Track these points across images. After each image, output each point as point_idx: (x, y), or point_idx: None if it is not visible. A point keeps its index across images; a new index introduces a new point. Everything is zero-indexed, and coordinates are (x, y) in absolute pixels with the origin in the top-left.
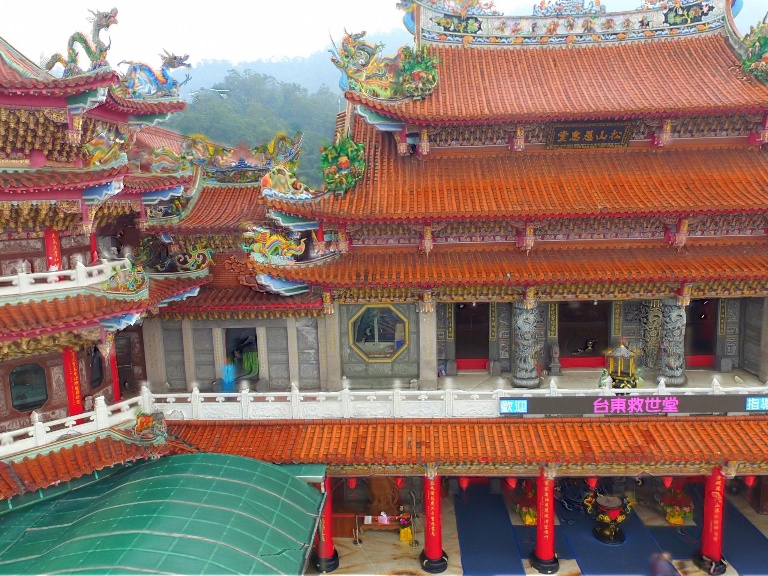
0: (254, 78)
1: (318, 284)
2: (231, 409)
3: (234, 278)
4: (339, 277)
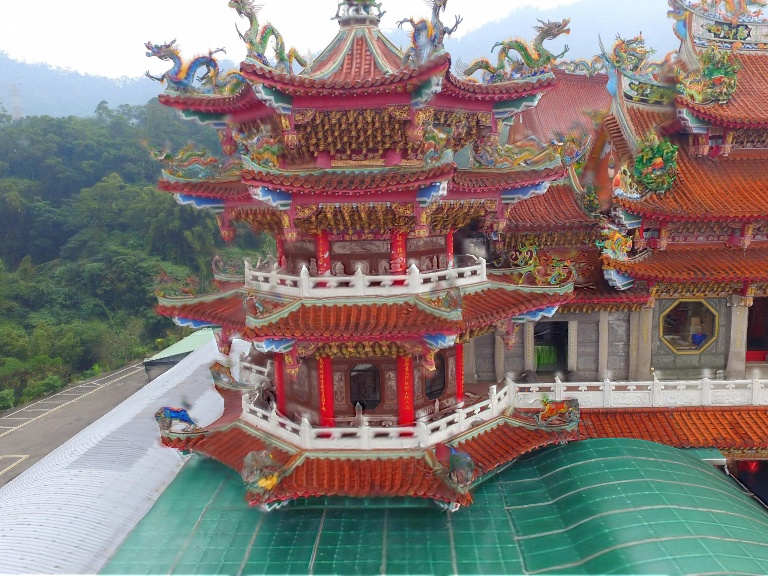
0: None
1: (652, 279)
2: (592, 398)
3: None
4: (677, 272)
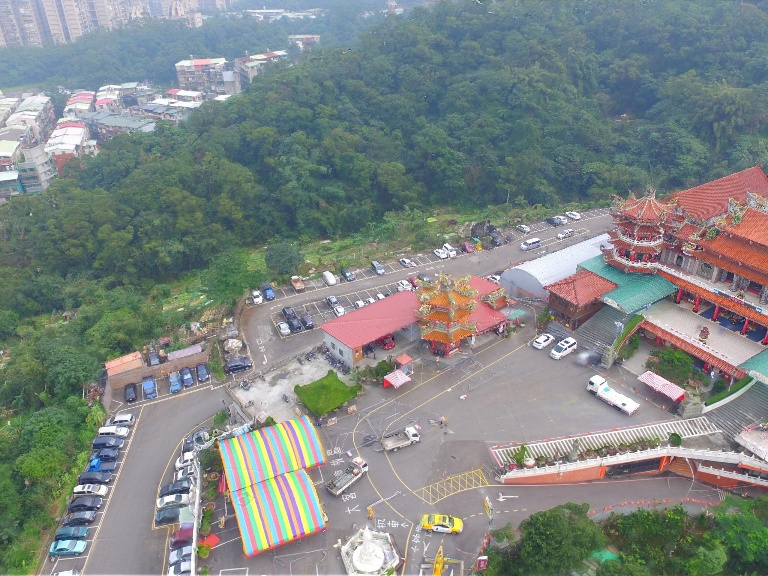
0: None
1: None
2: (670, 271)
3: None
4: None
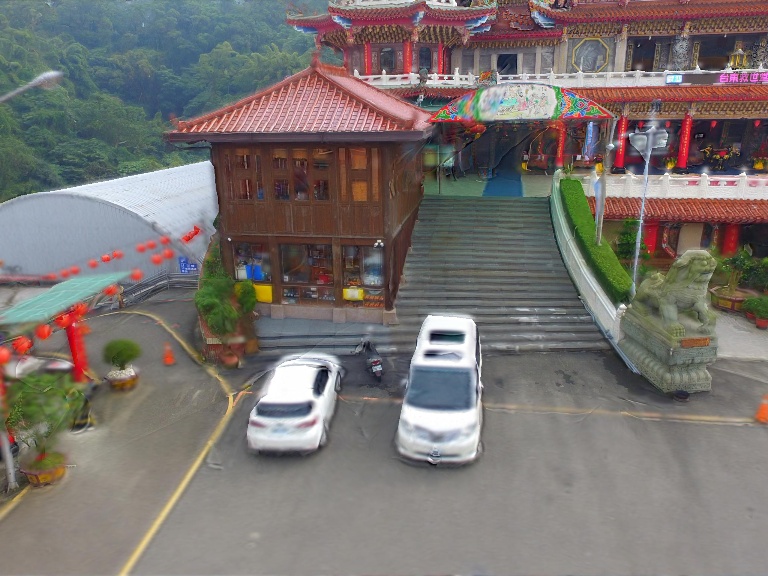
0: None
1: (563, 20)
2: None
3: (507, 24)
4: (577, 15)
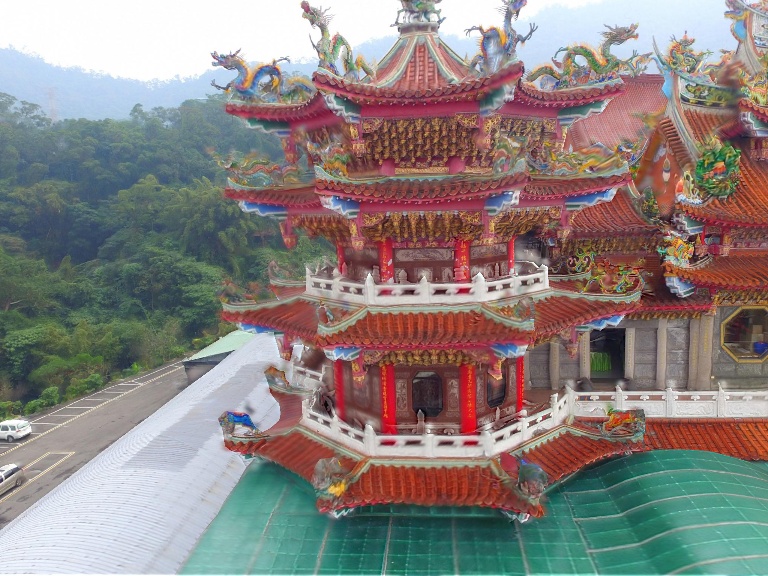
0: (306, 79)
1: (715, 286)
2: (654, 407)
3: None
4: (741, 280)
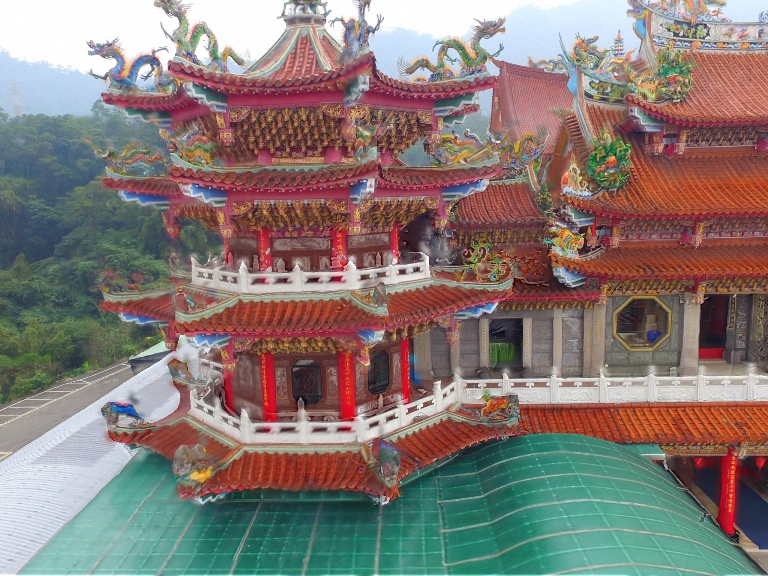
0: None
1: (602, 276)
2: (540, 394)
3: None
4: (626, 270)
